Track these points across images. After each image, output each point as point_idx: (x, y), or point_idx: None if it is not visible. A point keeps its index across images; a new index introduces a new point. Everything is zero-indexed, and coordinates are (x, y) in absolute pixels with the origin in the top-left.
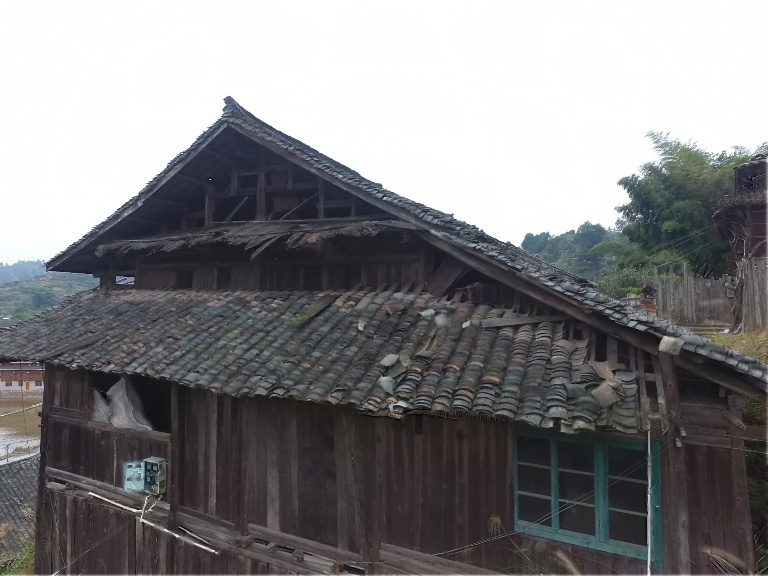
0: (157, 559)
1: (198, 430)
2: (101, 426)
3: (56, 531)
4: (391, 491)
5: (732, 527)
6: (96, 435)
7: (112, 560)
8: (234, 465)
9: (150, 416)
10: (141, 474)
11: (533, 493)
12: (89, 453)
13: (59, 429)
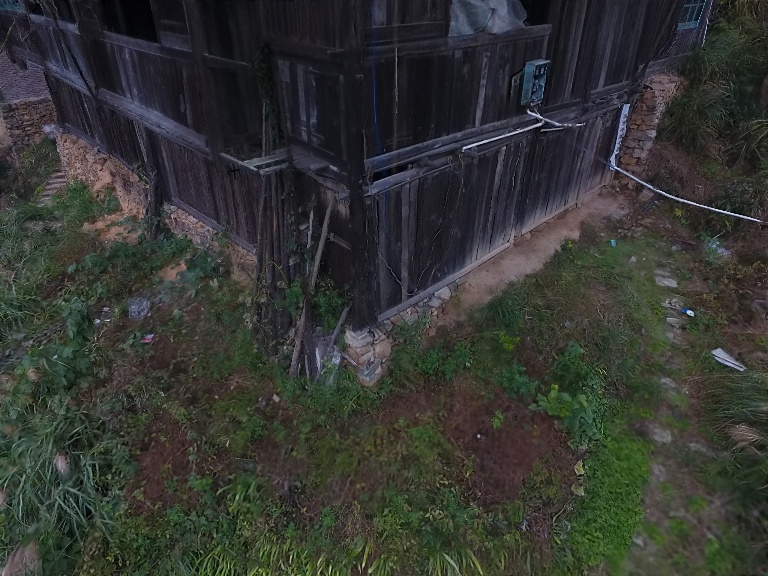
0: (514, 179)
1: (575, 9)
2: (471, 40)
3: (379, 254)
4: (650, 26)
5: (714, 1)
6: (456, 61)
7: (469, 218)
8: (591, 40)
9: (533, 3)
10: (512, 92)
11: (687, 5)
12: (446, 96)
13: (387, 75)
